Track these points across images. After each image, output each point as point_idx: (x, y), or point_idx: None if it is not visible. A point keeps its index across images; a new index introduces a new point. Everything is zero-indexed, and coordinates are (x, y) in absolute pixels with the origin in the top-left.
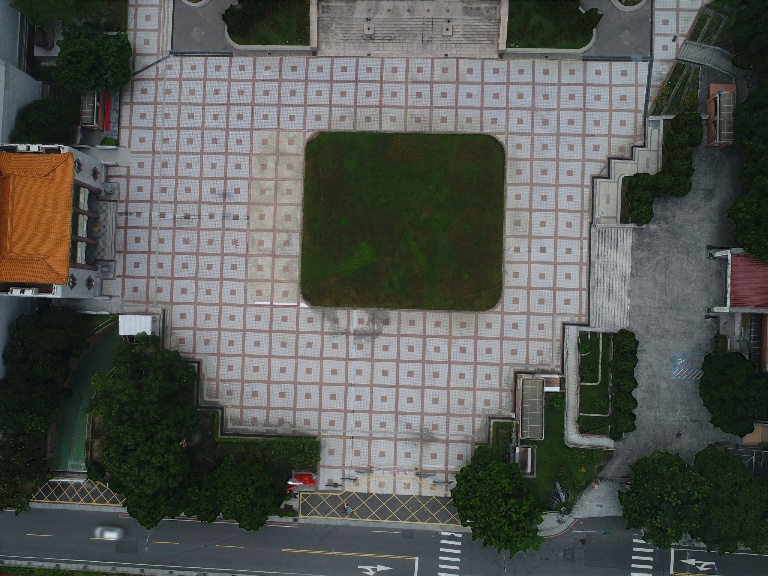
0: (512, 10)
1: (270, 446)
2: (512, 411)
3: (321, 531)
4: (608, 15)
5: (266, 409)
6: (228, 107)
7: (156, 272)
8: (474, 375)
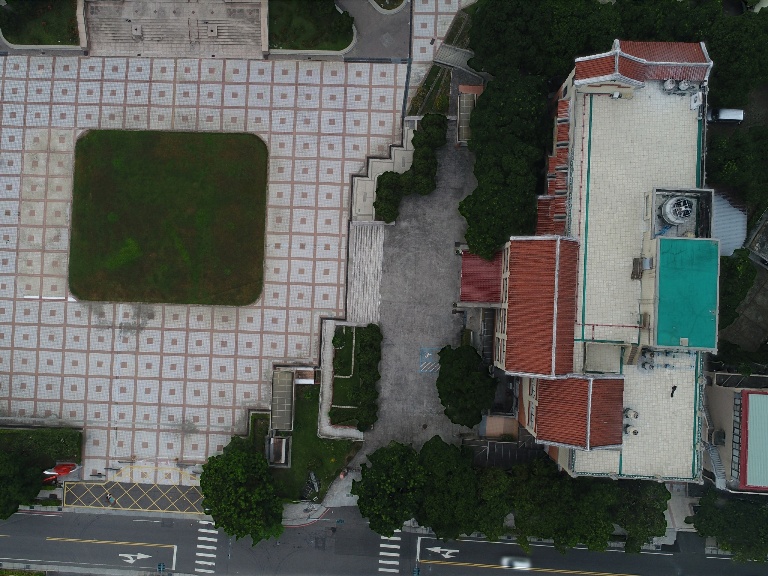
0: (274, 12)
1: (28, 437)
2: (270, 403)
3: (84, 520)
4: (369, 18)
5: (33, 401)
6: (2, 105)
7: None
8: (235, 368)
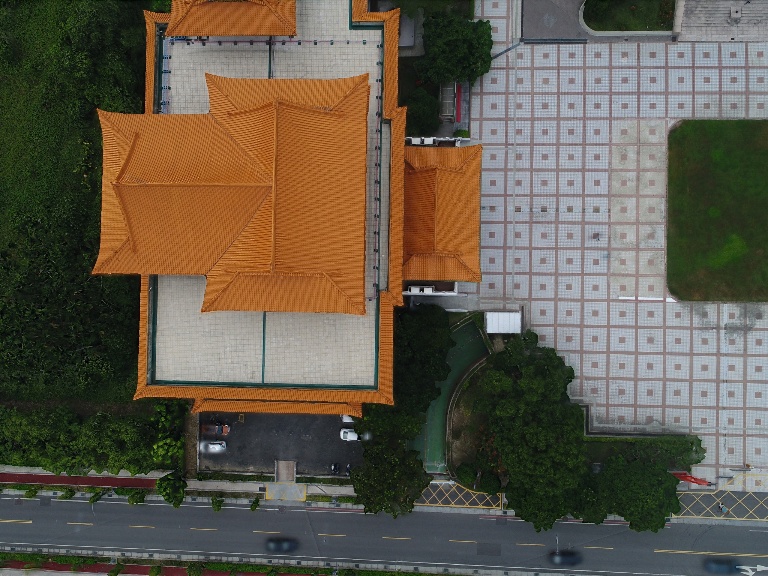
0: None
1: (653, 445)
2: None
3: (695, 531)
4: None
5: (633, 407)
6: (584, 96)
7: (513, 268)
8: None
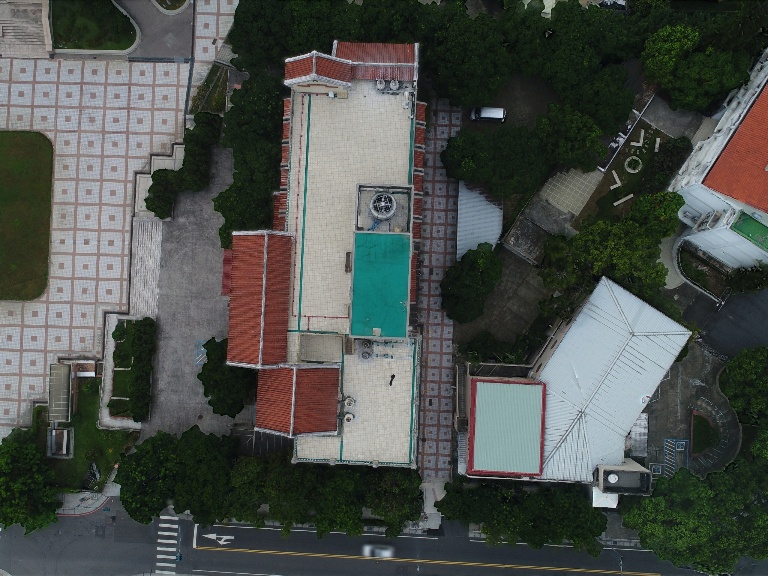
0: (57, 13)
1: None
2: None
3: None
4: (152, 18)
5: None
6: None
7: None
8: (20, 361)
